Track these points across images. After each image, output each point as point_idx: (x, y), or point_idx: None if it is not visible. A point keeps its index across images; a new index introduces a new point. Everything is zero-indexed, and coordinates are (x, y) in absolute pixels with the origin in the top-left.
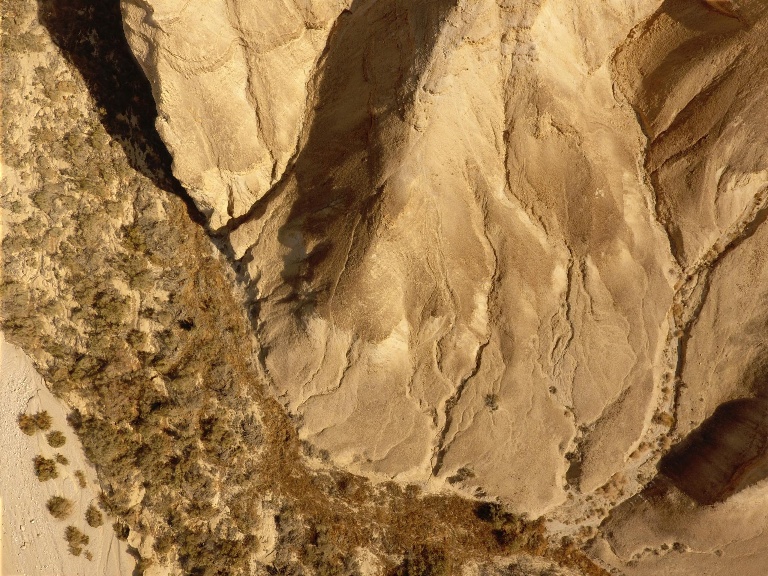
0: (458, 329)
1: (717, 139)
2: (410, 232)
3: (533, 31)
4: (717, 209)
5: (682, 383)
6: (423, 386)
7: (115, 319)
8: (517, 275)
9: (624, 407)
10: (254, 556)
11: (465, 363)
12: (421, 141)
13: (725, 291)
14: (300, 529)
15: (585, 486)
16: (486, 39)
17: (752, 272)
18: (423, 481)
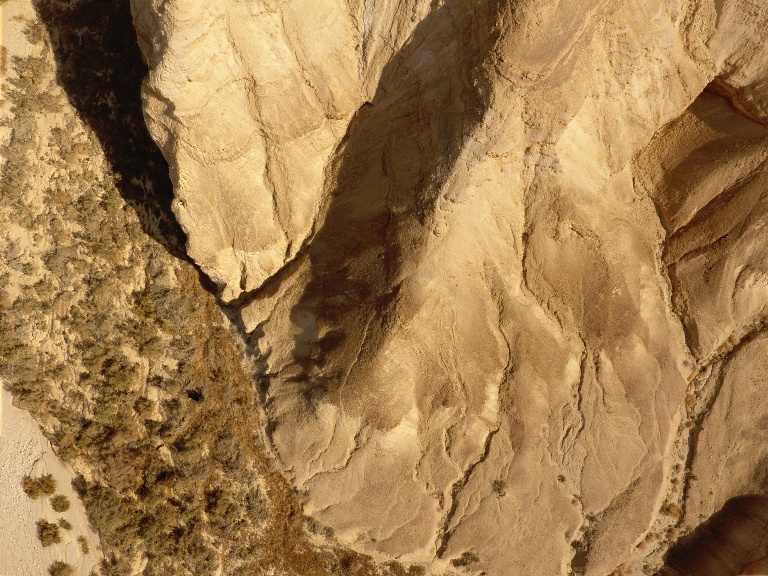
0: (468, 419)
1: (737, 240)
2: (425, 330)
3: (558, 146)
4: (734, 303)
5: (692, 475)
6: (430, 470)
7: (123, 387)
8: (530, 368)
9: (633, 498)
10: None
11: (474, 449)
12: (440, 246)
13: (739, 385)
14: None
15: (590, 575)
16: (510, 153)
17: (767, 371)
18: (427, 562)
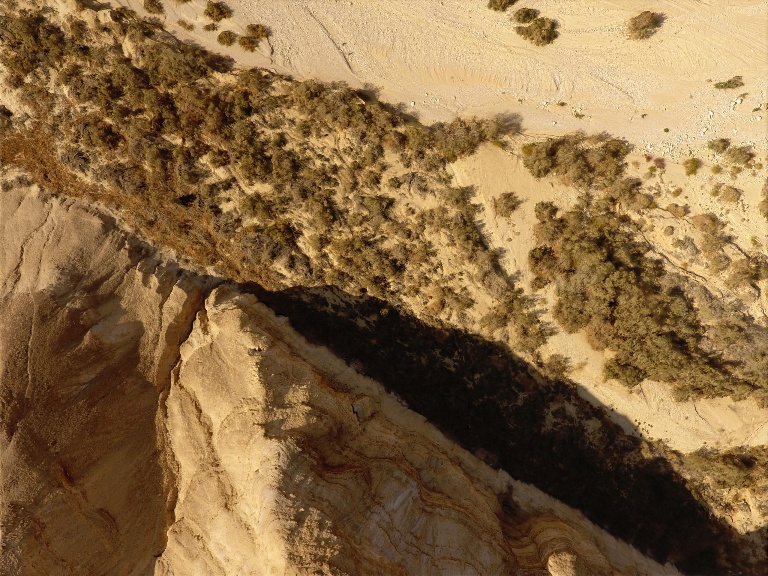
0: None
1: None
2: None
3: None
4: None
5: None
6: None
7: None
8: None
9: None
10: (6, 74)
11: None
12: None
13: None
14: None
15: None
16: None
17: None
18: None
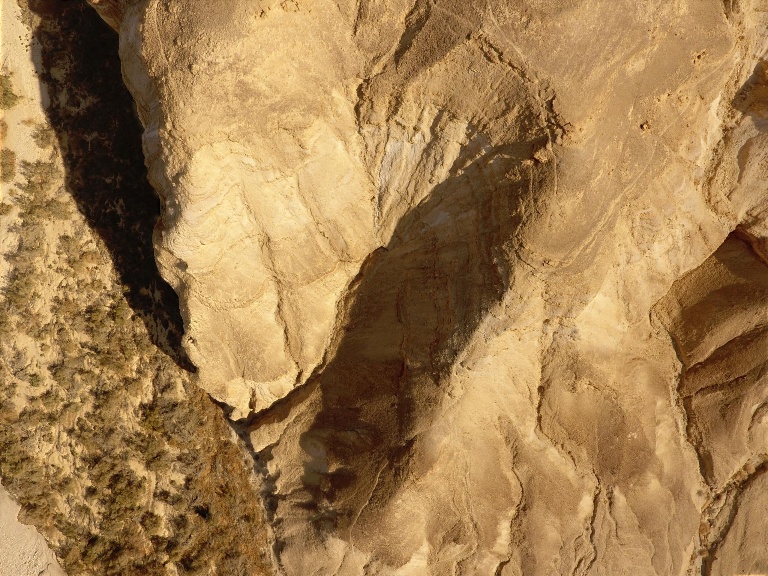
0: (479, 555)
1: (756, 382)
2: (438, 481)
3: (577, 319)
4: (750, 435)
5: None
6: None
7: (130, 503)
8: (543, 507)
9: None
10: None
11: None
12: (455, 406)
13: (753, 515)
14: None
15: None
16: None
17: None
18: None
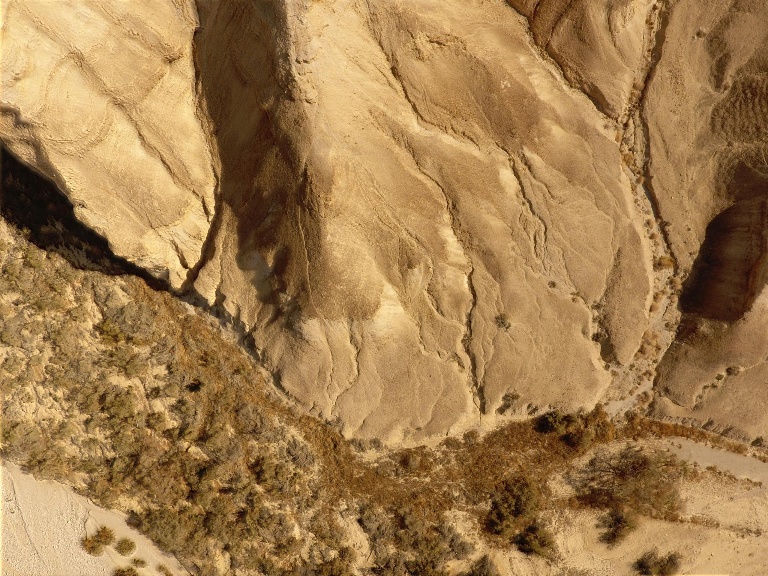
0: (439, 269)
1: None
2: (350, 200)
3: None
4: (620, 52)
5: (664, 223)
6: (434, 337)
7: (127, 412)
8: (468, 195)
9: (623, 269)
10: (356, 566)
11: (461, 298)
12: (319, 111)
13: (663, 122)
14: (386, 521)
15: (622, 357)
16: None
17: (677, 92)
18: (476, 424)
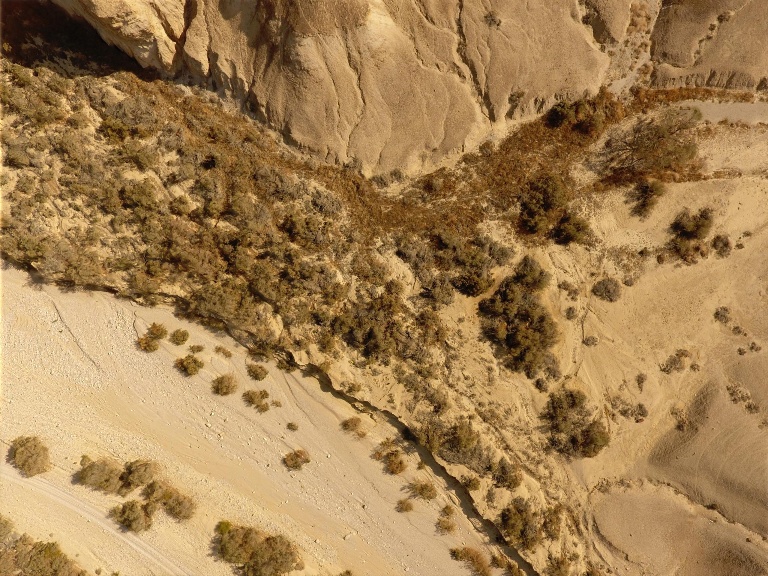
0: None
1: None
2: None
3: None
4: None
5: None
6: (429, 49)
7: (149, 201)
8: None
9: None
10: (404, 296)
11: (447, 1)
12: None
13: None
14: (423, 247)
15: (615, 32)
16: None
17: None
18: (489, 134)
